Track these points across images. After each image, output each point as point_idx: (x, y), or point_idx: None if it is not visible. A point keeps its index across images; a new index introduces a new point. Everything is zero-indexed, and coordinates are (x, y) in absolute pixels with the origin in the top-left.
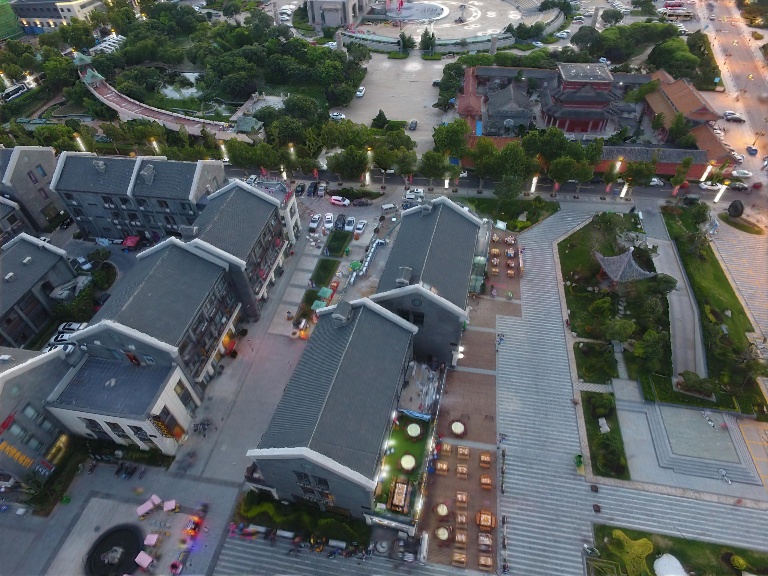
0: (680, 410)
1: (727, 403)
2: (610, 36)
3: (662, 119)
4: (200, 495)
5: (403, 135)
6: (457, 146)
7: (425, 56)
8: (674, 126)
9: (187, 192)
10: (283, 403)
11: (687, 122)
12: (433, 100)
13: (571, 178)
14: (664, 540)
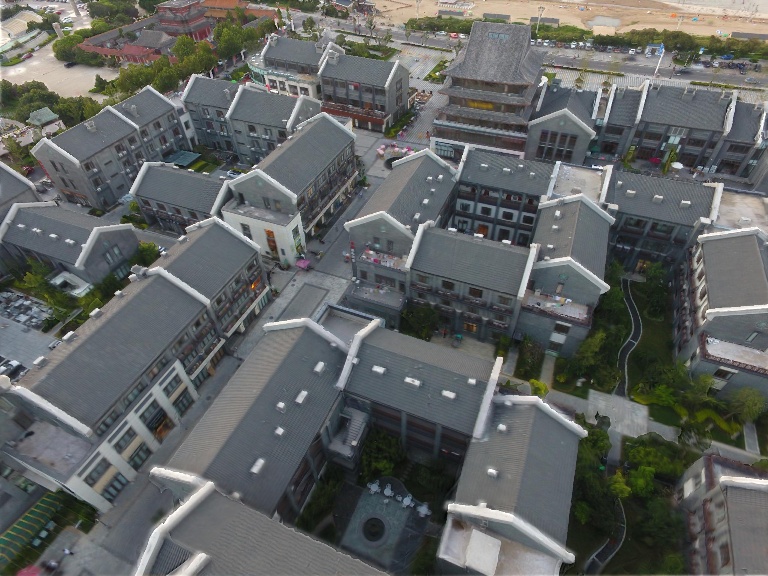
0: (391, 59)
1: (393, 51)
2: (112, 5)
3: (231, 13)
4: (379, 147)
5: (163, 60)
6: (194, 52)
7: (7, 64)
8: (240, 13)
9: (166, 105)
10: (366, 81)
11: (241, 10)
12: (91, 71)
13: (255, 39)
14: (431, 72)
